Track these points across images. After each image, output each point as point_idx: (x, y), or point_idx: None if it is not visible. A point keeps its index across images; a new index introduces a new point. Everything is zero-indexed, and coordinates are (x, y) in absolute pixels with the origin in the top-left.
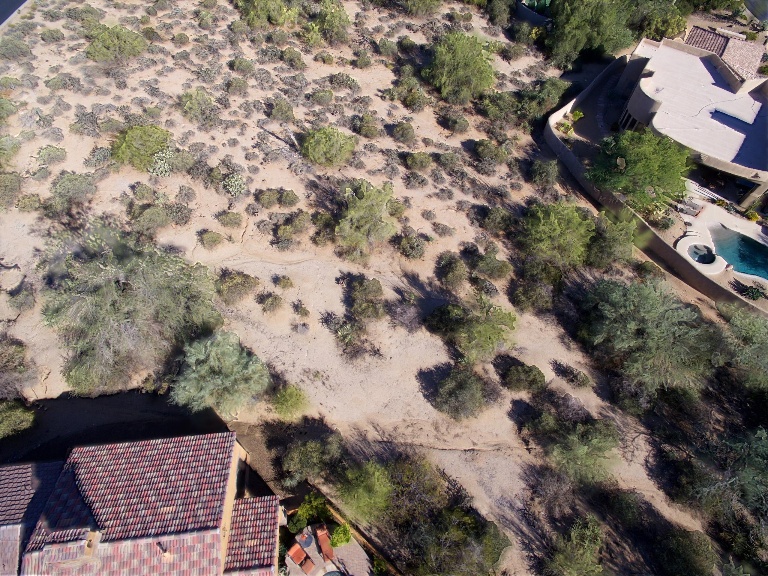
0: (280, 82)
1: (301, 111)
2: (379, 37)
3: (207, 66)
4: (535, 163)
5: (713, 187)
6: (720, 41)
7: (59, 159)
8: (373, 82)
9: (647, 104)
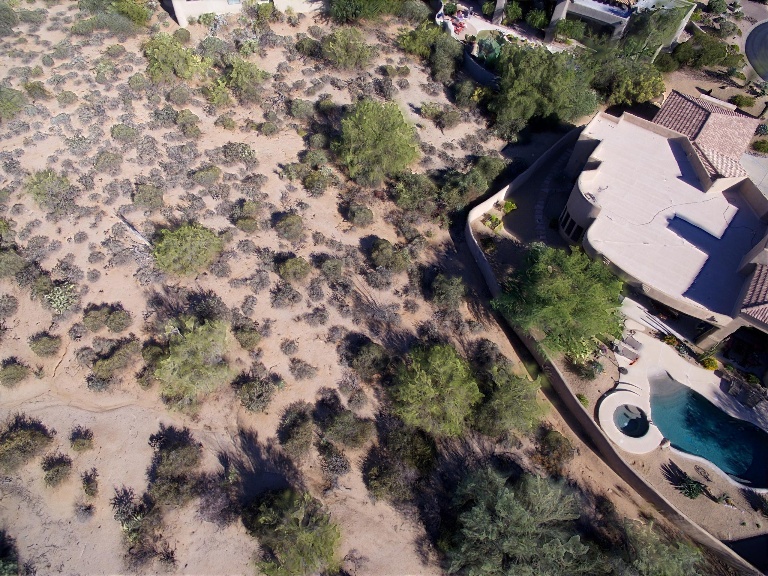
0: (165, 154)
1: (177, 194)
2: (297, 95)
3: (86, 132)
4: (436, 278)
5: (664, 317)
6: (699, 115)
7: None
8: (276, 154)
9: (585, 207)
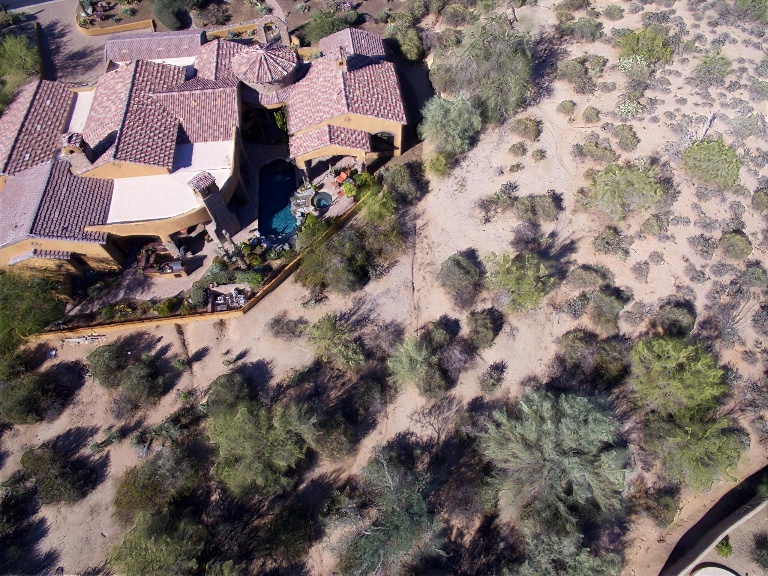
0: None
1: (761, 145)
2: None
3: None
4: None
5: None
6: None
7: (612, 17)
8: None
9: None
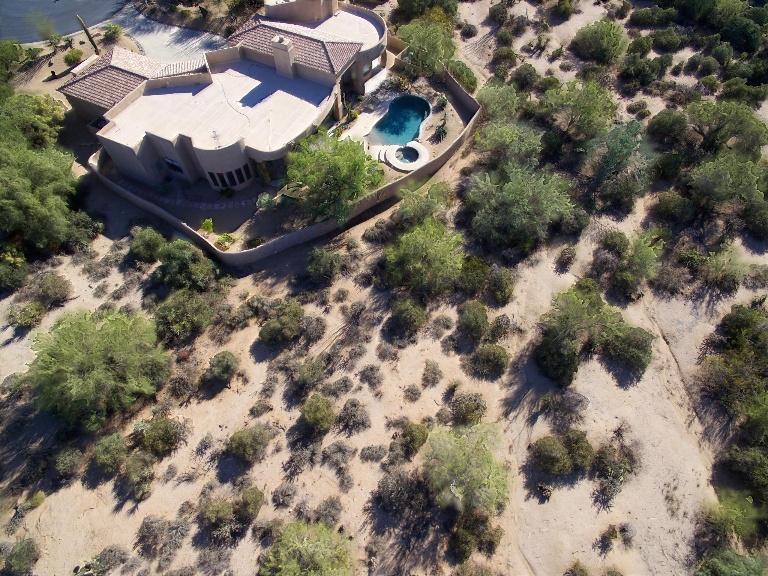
0: None
1: None
2: None
3: None
4: (313, 272)
5: None
6: (111, 74)
7: None
8: (89, 526)
9: (235, 151)
